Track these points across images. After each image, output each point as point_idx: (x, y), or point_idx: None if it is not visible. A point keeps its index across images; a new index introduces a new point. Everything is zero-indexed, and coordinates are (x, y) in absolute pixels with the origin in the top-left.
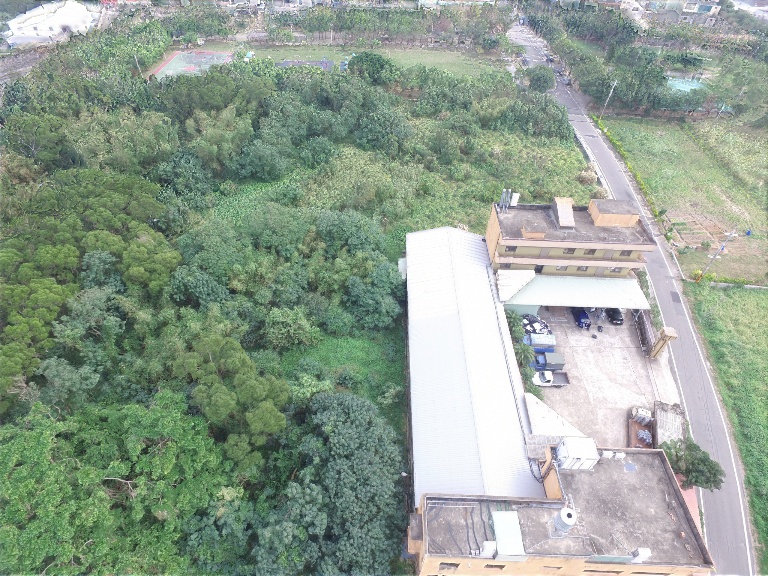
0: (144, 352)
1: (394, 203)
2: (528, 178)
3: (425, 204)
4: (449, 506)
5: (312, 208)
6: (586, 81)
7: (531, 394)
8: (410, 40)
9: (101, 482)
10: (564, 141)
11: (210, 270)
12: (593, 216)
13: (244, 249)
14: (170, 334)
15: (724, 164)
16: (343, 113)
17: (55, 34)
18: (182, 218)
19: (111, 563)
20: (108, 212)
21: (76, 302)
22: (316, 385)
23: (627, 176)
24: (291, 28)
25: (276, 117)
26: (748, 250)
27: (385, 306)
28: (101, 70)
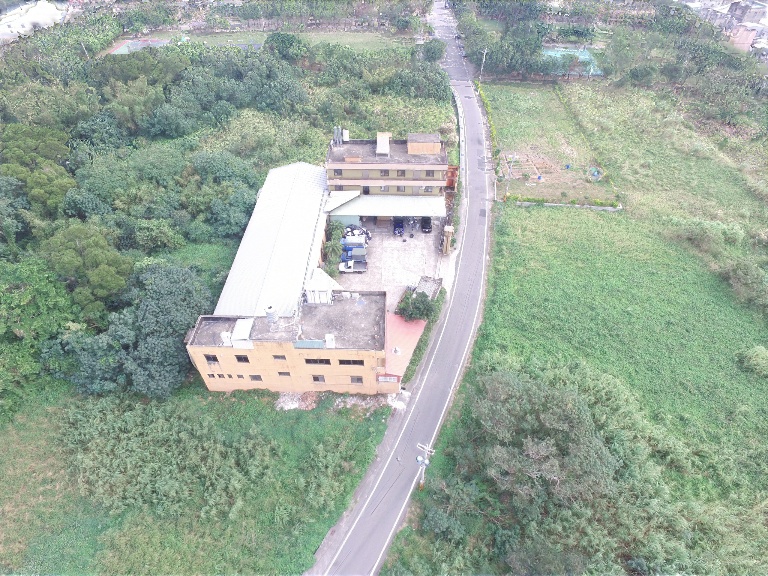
0: (38, 249)
1: (271, 150)
2: (396, 130)
3: (301, 151)
4: (219, 324)
5: (196, 152)
6: None
7: (319, 268)
8: (336, 24)
9: None
10: (441, 102)
11: (96, 192)
12: (407, 146)
13: (128, 178)
14: None
15: (575, 116)
16: (246, 82)
17: (27, 31)
18: None
19: None
20: (21, 151)
21: None
22: (153, 261)
23: (485, 127)
24: (233, 18)
25: (187, 86)
26: (562, 179)
27: (234, 218)
28: None
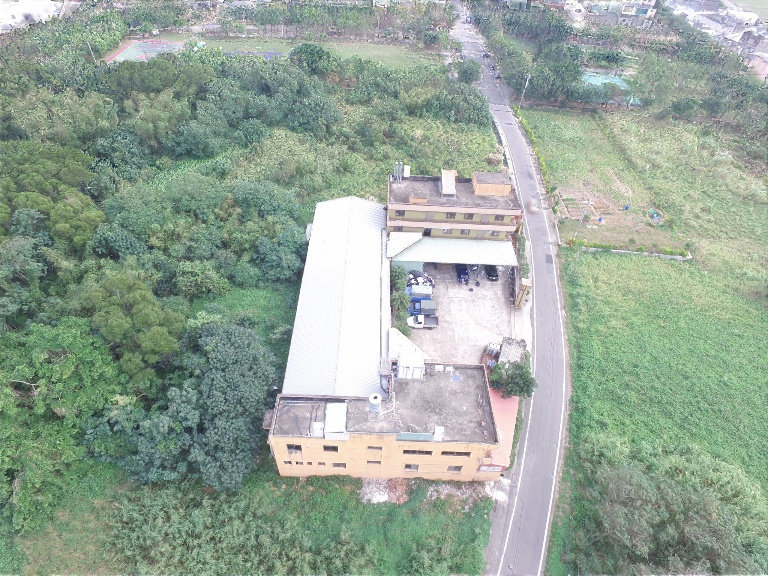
0: (65, 295)
1: (313, 178)
2: (441, 159)
3: (343, 180)
4: (299, 404)
5: (234, 179)
6: (510, 74)
7: (395, 328)
8: (358, 34)
9: (9, 384)
10: (482, 128)
11: (130, 228)
12: (474, 186)
13: (164, 211)
14: (90, 280)
15: (622, 150)
16: (277, 98)
17: (18, 22)
18: (114, 186)
19: (14, 447)
20: (40, 177)
21: (2, 249)
22: (208, 318)
23: (532, 159)
24: (247, 21)
25: (213, 100)
26: (623, 222)
27: (287, 261)
28: (55, 56)
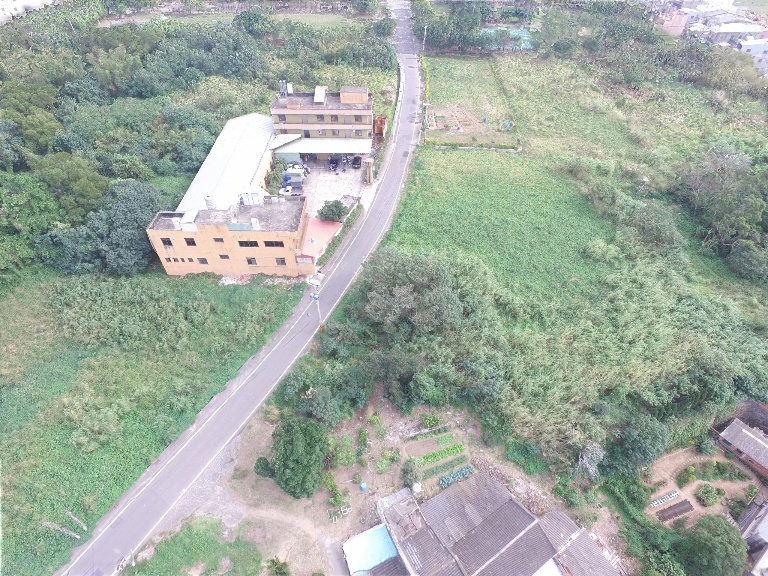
0: None
1: (232, 106)
2: None
3: (259, 109)
4: None
5: None
6: None
7: None
8: (303, 7)
9: None
10: (387, 70)
11: (80, 133)
12: None
13: None
14: None
15: (501, 82)
16: (214, 52)
17: (19, 14)
18: None
19: None
20: (16, 100)
21: None
22: None
23: (421, 90)
24: (210, 2)
25: (161, 55)
26: (478, 130)
27: (195, 155)
28: None
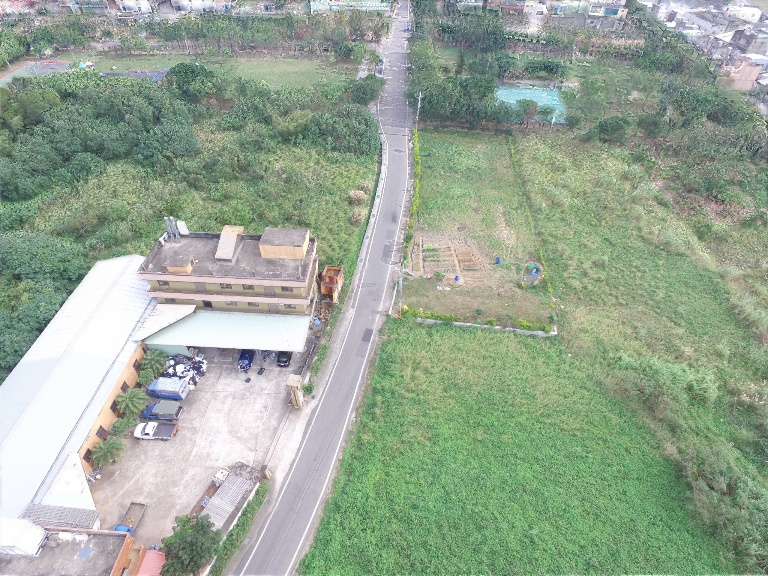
0: None
1: None
2: (292, 198)
3: (163, 226)
4: None
5: (8, 233)
6: None
7: (77, 454)
8: (272, 48)
9: None
10: (363, 157)
11: None
12: None
13: None
14: None
15: (523, 182)
16: (121, 128)
17: None
18: None
19: None
20: None
21: None
22: None
23: (407, 196)
24: None
25: (43, 133)
26: (487, 281)
27: (13, 344)
28: None
